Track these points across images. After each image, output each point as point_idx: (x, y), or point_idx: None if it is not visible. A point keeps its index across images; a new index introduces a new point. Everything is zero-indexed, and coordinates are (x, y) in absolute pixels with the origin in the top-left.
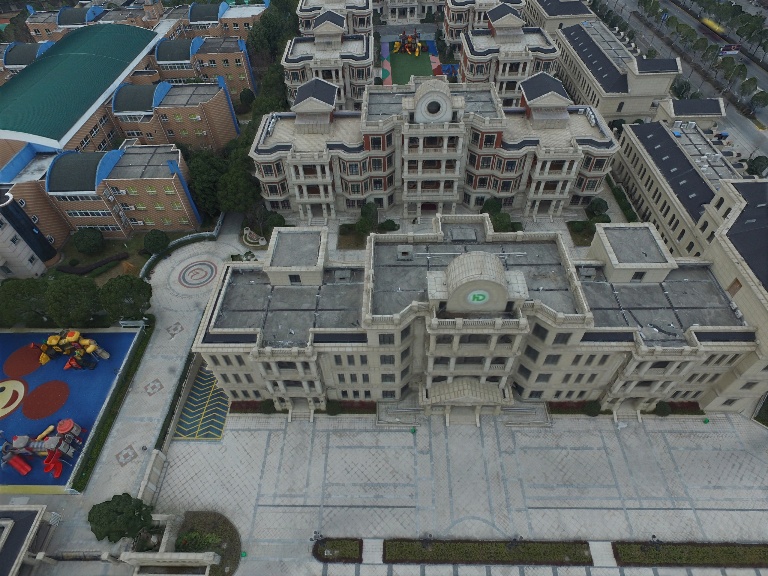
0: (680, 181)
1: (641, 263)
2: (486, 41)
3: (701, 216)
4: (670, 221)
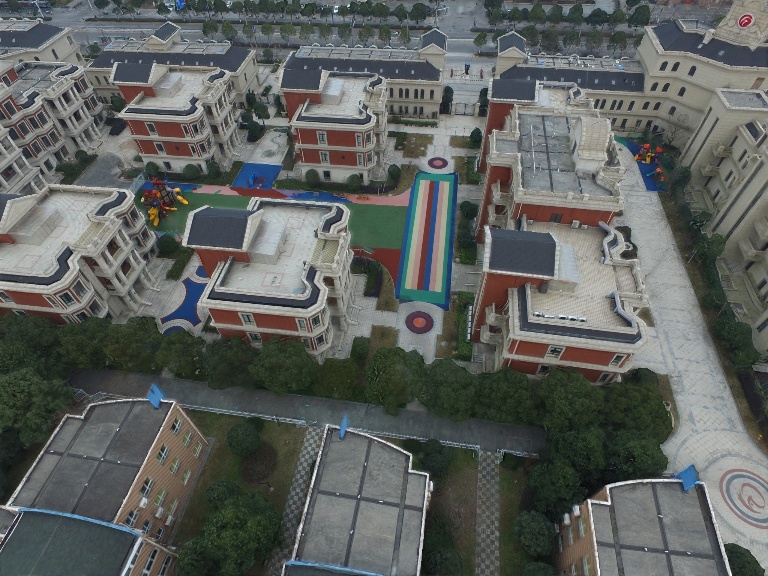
0: (594, 82)
1: (767, 101)
2: (328, 110)
3: (646, 84)
4: (611, 107)
